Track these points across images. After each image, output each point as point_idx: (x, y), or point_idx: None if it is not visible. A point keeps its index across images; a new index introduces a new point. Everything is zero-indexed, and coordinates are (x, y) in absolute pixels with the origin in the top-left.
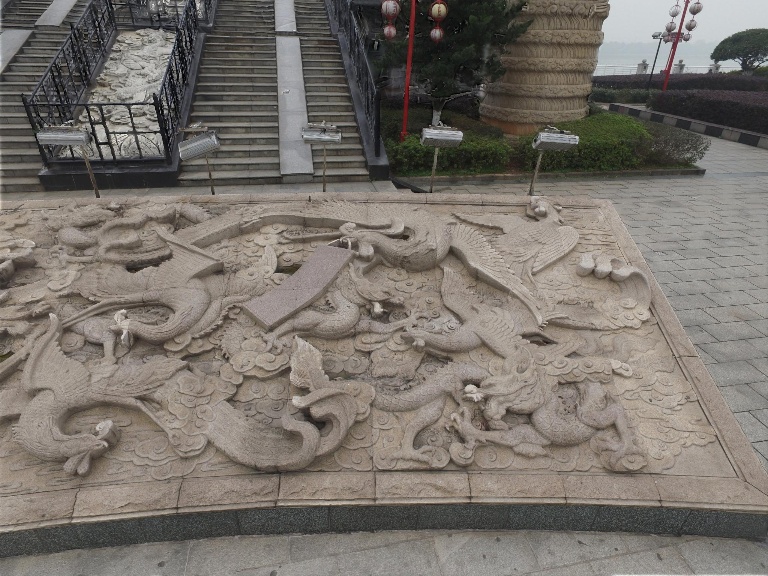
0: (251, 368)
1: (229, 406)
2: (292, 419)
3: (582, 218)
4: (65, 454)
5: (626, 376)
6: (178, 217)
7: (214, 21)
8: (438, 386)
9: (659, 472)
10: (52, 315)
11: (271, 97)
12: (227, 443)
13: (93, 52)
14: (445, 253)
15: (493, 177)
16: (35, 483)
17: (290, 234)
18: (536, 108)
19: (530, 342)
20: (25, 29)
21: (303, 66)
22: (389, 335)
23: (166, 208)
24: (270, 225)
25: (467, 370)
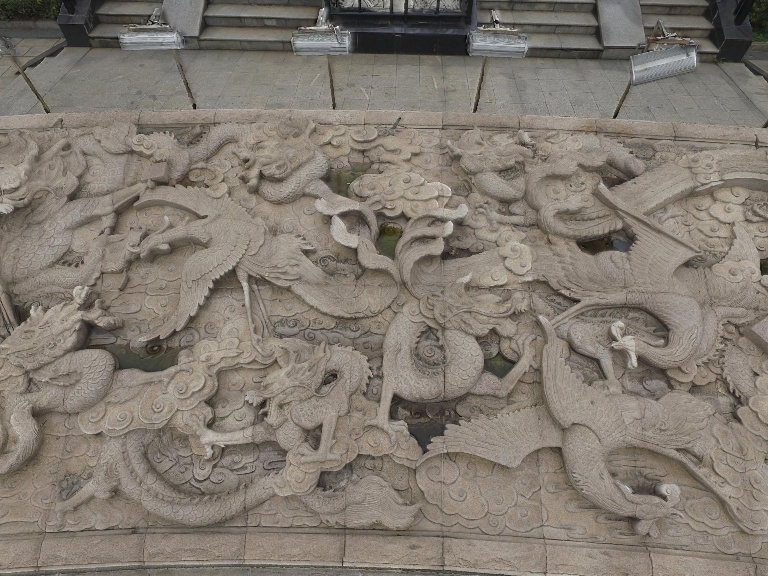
0: None
1: None
2: None
3: None
4: (640, 517)
5: None
6: None
7: None
8: None
9: None
10: (544, 319)
11: None
12: None
13: None
14: None
15: None
16: (598, 531)
17: (760, 208)
18: None
19: None
20: None
21: None
22: None
23: (583, 145)
24: (727, 188)
25: None
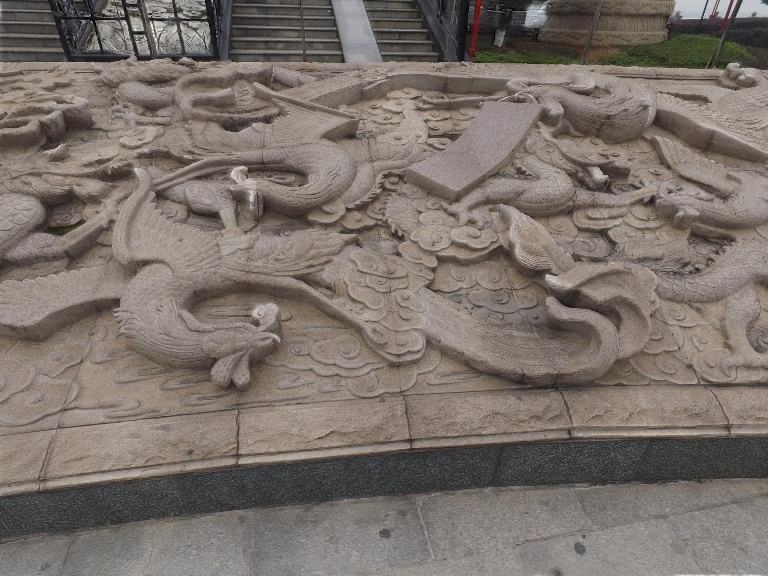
0: (447, 246)
1: (435, 294)
2: (561, 305)
3: None
4: (211, 353)
5: None
6: (272, 81)
7: None
8: (747, 266)
9: None
10: (139, 170)
11: (322, 1)
12: (461, 342)
13: None
14: (653, 117)
15: None
16: (161, 402)
17: None
18: (612, 28)
19: None
20: None
21: None
22: (627, 208)
23: None
24: (399, 89)
25: None
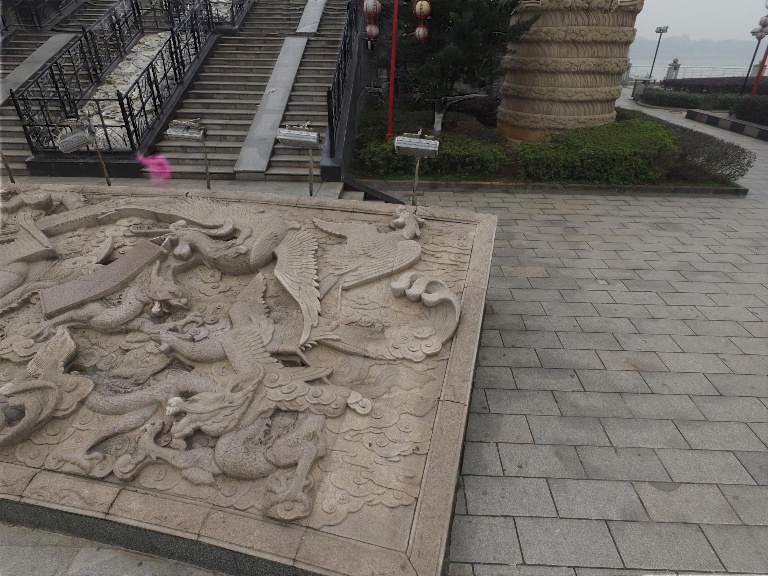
0: (9, 351)
1: None
2: None
3: (450, 233)
4: None
5: (359, 413)
6: (57, 205)
7: (242, 23)
8: (151, 394)
9: (317, 527)
10: None
11: (258, 96)
12: None
13: (108, 53)
14: (263, 258)
15: (478, 185)
16: None
17: (138, 228)
18: (548, 112)
19: (277, 361)
20: (80, 33)
21: (300, 66)
22: None
23: None
24: (127, 218)
25: (193, 382)
